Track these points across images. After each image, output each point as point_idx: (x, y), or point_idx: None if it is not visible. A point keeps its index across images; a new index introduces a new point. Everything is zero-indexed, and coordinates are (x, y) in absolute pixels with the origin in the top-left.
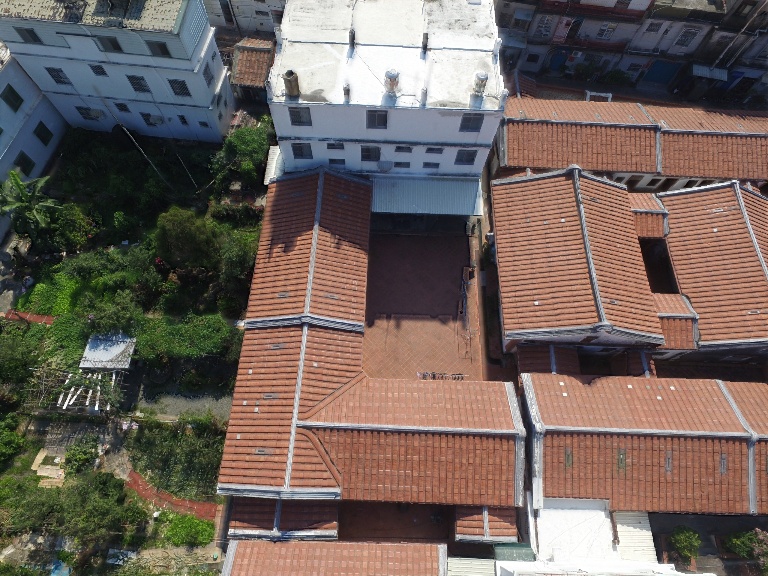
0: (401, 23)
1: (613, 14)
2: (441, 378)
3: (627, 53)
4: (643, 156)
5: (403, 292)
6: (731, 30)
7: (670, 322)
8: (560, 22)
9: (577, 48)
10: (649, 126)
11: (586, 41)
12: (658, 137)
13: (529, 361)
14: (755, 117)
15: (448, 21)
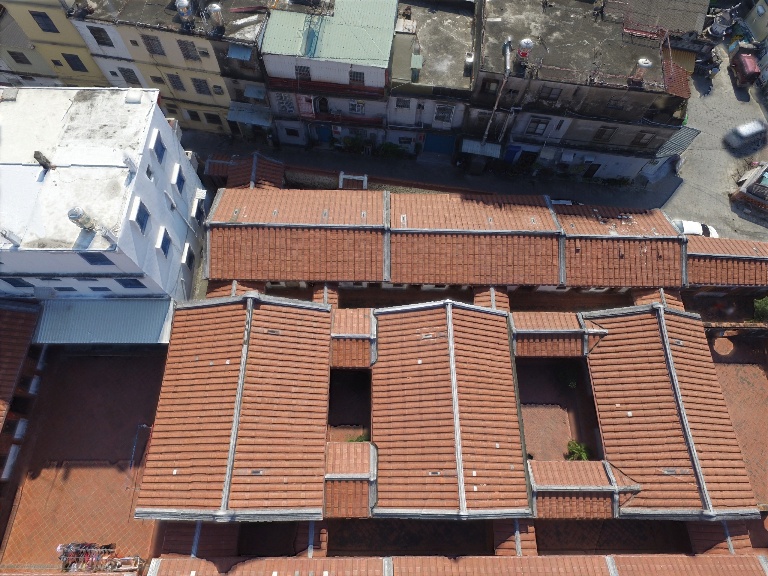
0: (32, 132)
1: (353, 91)
2: (85, 552)
3: (387, 128)
4: (368, 262)
5: (85, 431)
6: (485, 107)
7: (342, 484)
8: (298, 99)
9: (332, 123)
10: (375, 227)
11: (339, 116)
12: (386, 240)
13: (173, 537)
14: (515, 205)
15: (91, 127)
